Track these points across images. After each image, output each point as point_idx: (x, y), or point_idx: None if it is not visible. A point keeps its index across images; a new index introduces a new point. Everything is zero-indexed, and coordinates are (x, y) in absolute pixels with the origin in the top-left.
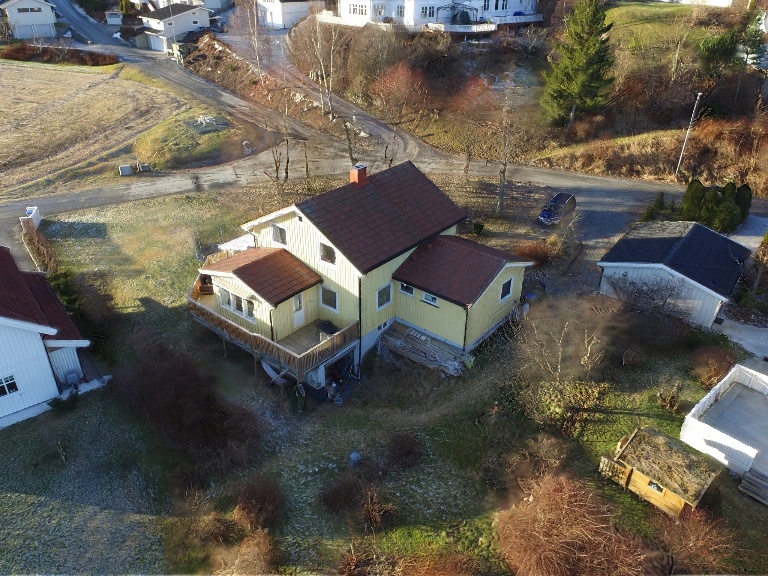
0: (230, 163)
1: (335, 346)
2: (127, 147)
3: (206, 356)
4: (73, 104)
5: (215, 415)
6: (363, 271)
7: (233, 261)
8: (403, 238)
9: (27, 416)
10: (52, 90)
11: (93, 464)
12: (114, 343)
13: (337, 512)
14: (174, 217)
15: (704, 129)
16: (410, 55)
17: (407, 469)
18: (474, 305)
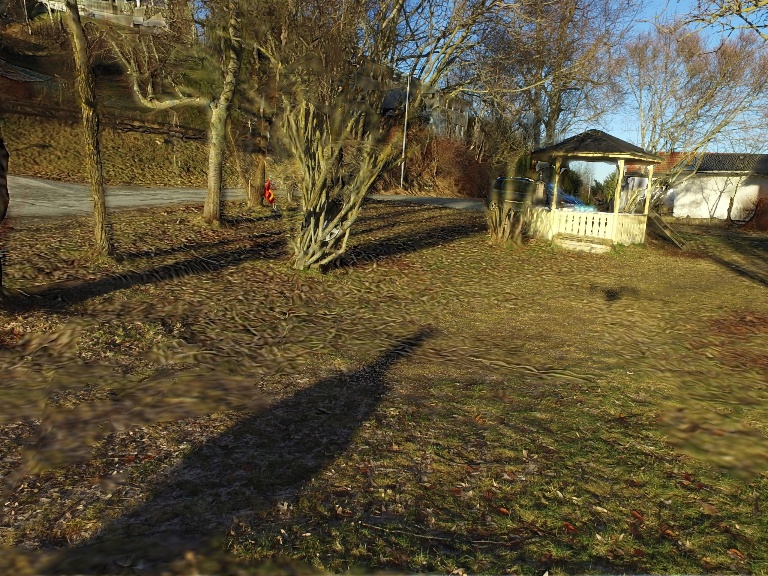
0: None
1: None
2: None
3: None
4: None
5: None
6: None
7: None
8: None
9: None
10: None
11: None
12: None
13: None
14: None
15: (389, 131)
16: None
17: None
18: None
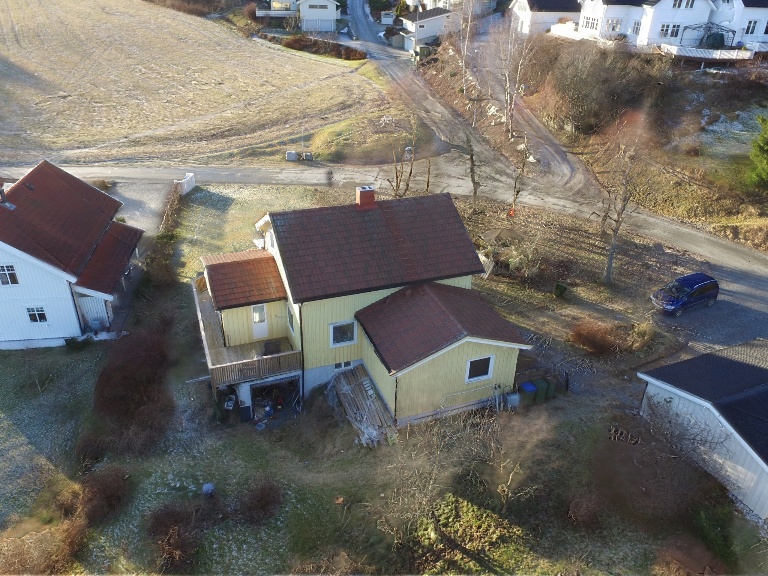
0: (382, 165)
1: (265, 369)
2: (308, 135)
3: (190, 340)
4: (300, 91)
5: (135, 396)
6: (297, 299)
7: (229, 257)
8: (375, 276)
9: (49, 345)
10: (296, 77)
11: (55, 402)
12: (155, 305)
13: (155, 535)
14: (288, 206)
15: None
16: (621, 78)
17: (247, 524)
18: (400, 373)
